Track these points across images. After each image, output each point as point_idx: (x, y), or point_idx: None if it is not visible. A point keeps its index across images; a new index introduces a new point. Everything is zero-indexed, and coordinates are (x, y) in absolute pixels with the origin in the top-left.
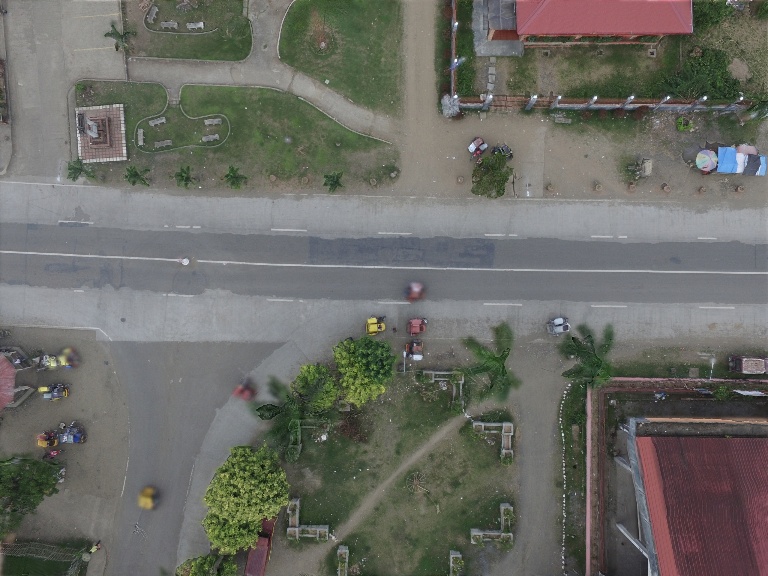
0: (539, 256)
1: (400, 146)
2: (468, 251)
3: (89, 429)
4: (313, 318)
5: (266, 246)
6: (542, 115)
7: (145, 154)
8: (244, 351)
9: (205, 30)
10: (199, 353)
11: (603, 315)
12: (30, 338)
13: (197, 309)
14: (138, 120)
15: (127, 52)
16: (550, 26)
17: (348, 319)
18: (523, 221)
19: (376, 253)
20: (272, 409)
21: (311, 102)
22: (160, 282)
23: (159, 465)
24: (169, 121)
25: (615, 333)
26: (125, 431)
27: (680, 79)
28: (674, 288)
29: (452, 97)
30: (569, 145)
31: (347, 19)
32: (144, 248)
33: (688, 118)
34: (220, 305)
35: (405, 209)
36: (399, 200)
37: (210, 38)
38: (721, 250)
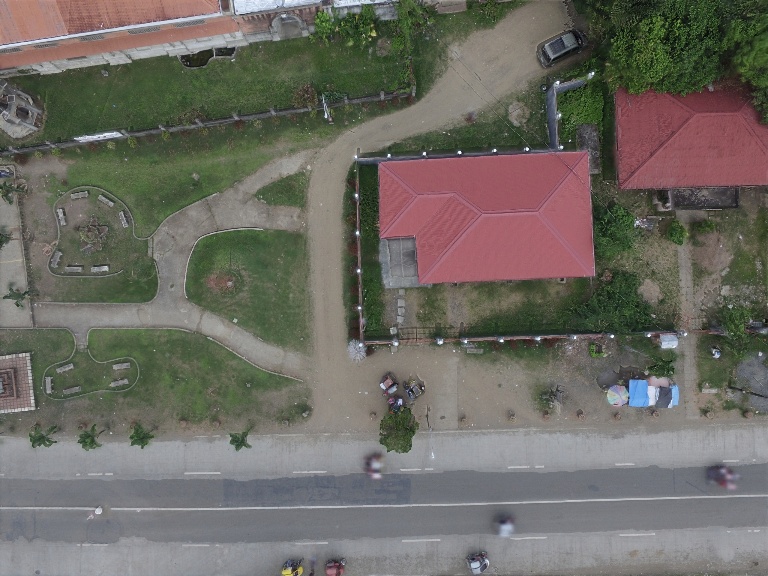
0: (456, 489)
1: (311, 383)
2: (384, 487)
3: None
4: (230, 562)
5: (180, 491)
6: (454, 346)
7: (54, 401)
8: None
9: (110, 272)
10: None
11: (523, 547)
12: None
13: (112, 558)
14: (46, 367)
15: (32, 299)
16: (451, 276)
17: (265, 562)
18: (439, 454)
19: (291, 493)
20: None
21: (220, 342)
22: (74, 532)
23: None
24: (77, 366)
25: (536, 564)
26: None
27: (588, 312)
28: (593, 516)
29: (358, 343)
30: (482, 375)
31: (253, 255)
32: (56, 498)
33: (601, 343)
34: (135, 553)
35: (319, 447)
36: (313, 438)
37: (116, 280)
38: (639, 475)
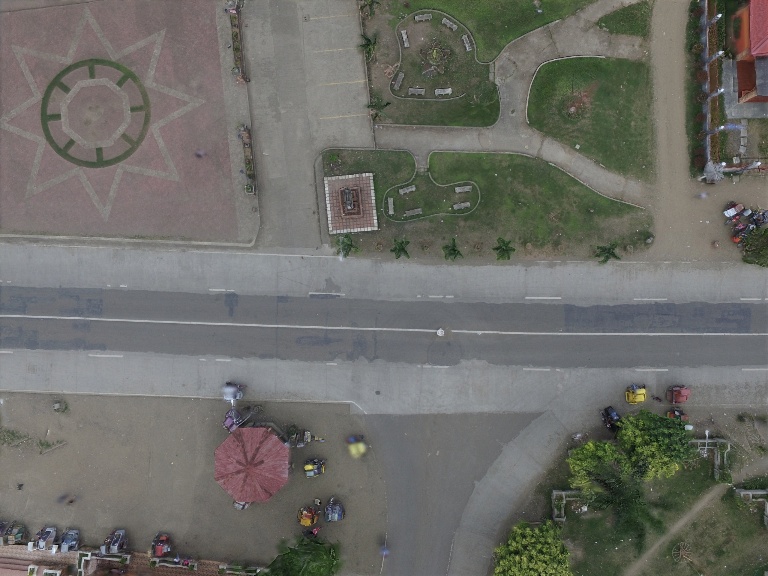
0: None
1: (653, 211)
2: (724, 316)
3: (346, 505)
4: (570, 387)
5: (521, 315)
6: None
7: (395, 223)
8: (501, 422)
9: (452, 96)
10: (456, 425)
11: None
12: (282, 413)
13: (453, 380)
14: (386, 188)
15: (374, 120)
16: None
17: (606, 387)
18: None
19: (632, 320)
20: (609, 501)
21: (562, 168)
22: (414, 353)
23: (419, 540)
24: (418, 189)
25: None
26: (382, 506)
27: None
28: None
29: (717, 164)
30: None
31: (595, 83)
32: (397, 319)
33: None
34: (476, 376)
35: (659, 274)
36: (653, 265)
37: (457, 104)
38: None
